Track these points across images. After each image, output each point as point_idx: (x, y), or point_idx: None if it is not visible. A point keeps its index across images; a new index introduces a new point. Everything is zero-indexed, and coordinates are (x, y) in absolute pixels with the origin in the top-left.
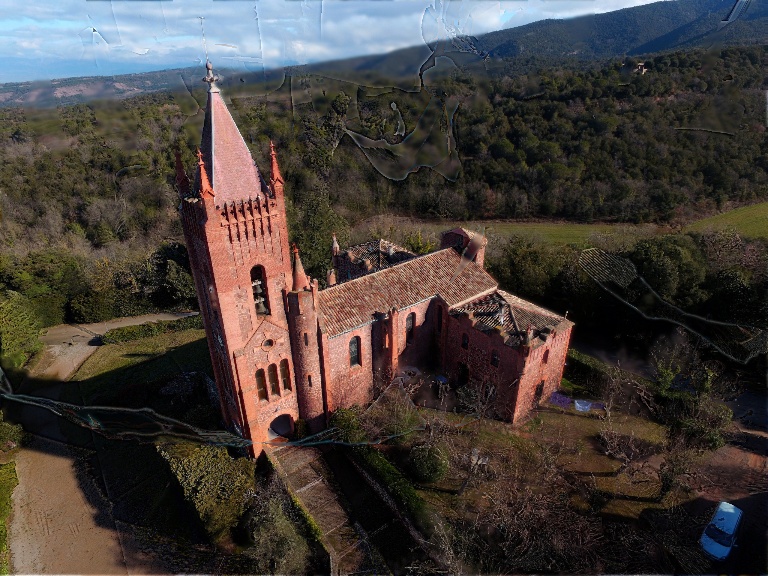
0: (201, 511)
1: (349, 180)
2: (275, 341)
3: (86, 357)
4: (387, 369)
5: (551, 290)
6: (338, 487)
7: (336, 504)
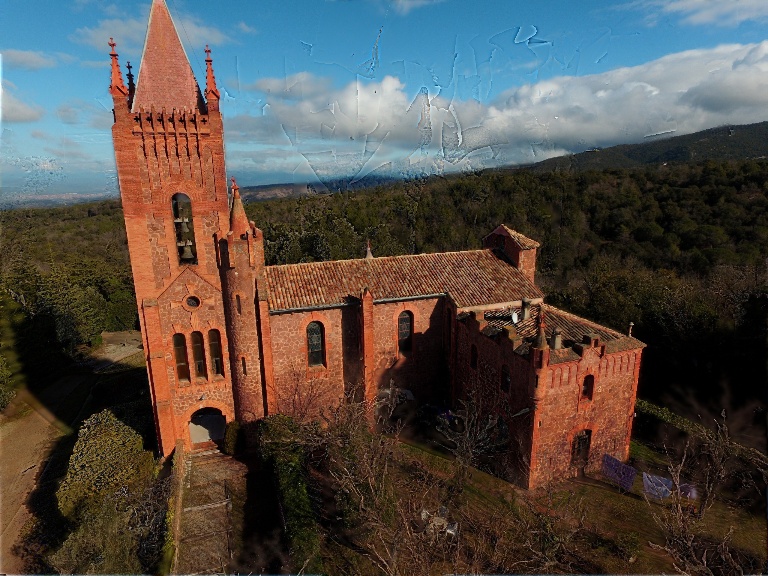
0: (59, 498)
1: (436, 226)
2: (202, 301)
3: (127, 356)
4: (362, 380)
5: (644, 329)
6: (241, 518)
7: (224, 539)
